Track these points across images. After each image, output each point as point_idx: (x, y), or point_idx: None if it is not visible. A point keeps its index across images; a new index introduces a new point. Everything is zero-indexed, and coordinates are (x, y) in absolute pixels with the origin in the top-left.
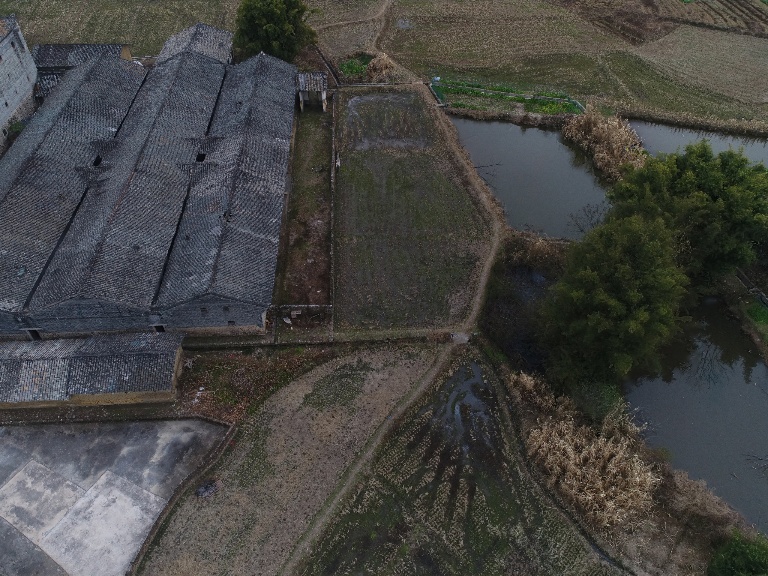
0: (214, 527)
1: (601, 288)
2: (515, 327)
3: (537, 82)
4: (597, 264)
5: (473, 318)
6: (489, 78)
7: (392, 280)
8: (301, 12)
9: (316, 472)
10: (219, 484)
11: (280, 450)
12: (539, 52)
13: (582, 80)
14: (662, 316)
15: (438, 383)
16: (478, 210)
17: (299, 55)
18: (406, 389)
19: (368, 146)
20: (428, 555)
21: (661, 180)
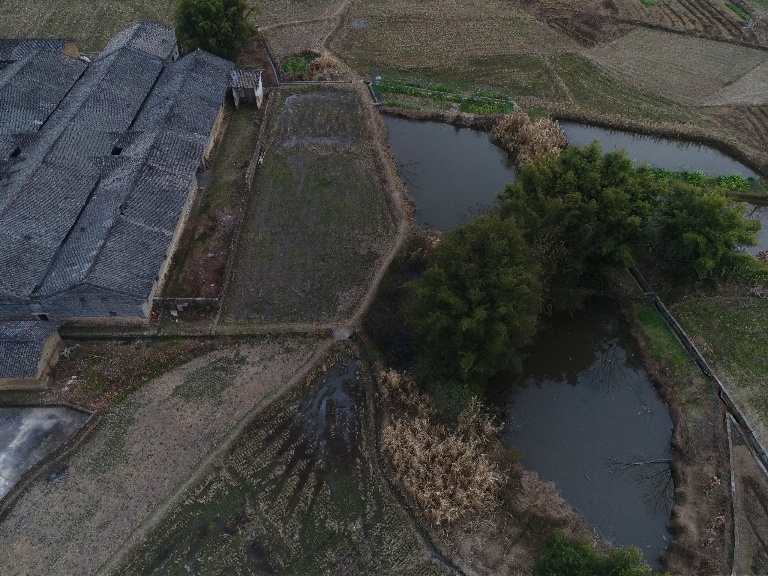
0: (57, 512)
1: (446, 286)
2: (390, 324)
3: (479, 82)
4: (448, 262)
5: (359, 315)
6: (431, 78)
7: (288, 276)
8: (241, 10)
9: (169, 462)
10: (71, 471)
11: (138, 439)
12: (487, 53)
13: (525, 81)
14: (507, 315)
15: (309, 378)
16: (389, 208)
17: (247, 53)
18: (276, 383)
19: (295, 143)
20: (261, 547)
21: (538, 180)
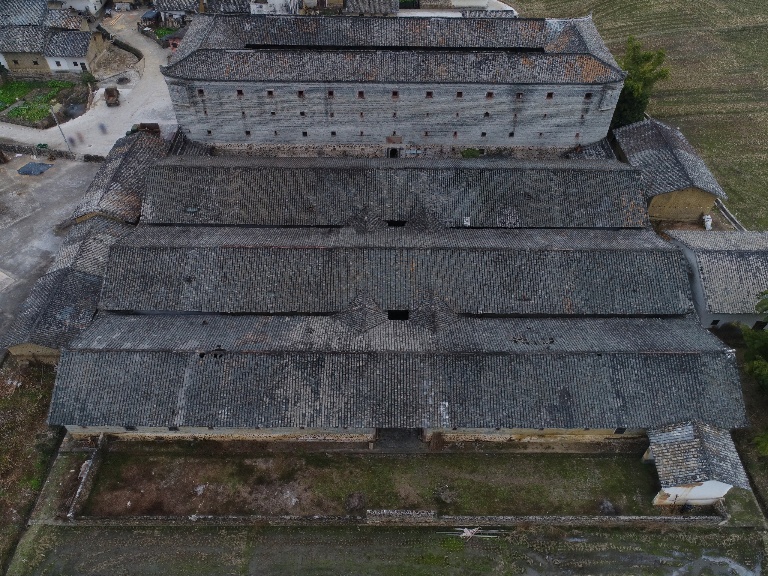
0: None
1: None
2: None
3: None
4: None
5: None
6: None
7: None
8: None
9: None
10: None
11: None
12: None
13: None
14: None
15: None
16: None
17: None
18: None
19: None
20: None
21: None
